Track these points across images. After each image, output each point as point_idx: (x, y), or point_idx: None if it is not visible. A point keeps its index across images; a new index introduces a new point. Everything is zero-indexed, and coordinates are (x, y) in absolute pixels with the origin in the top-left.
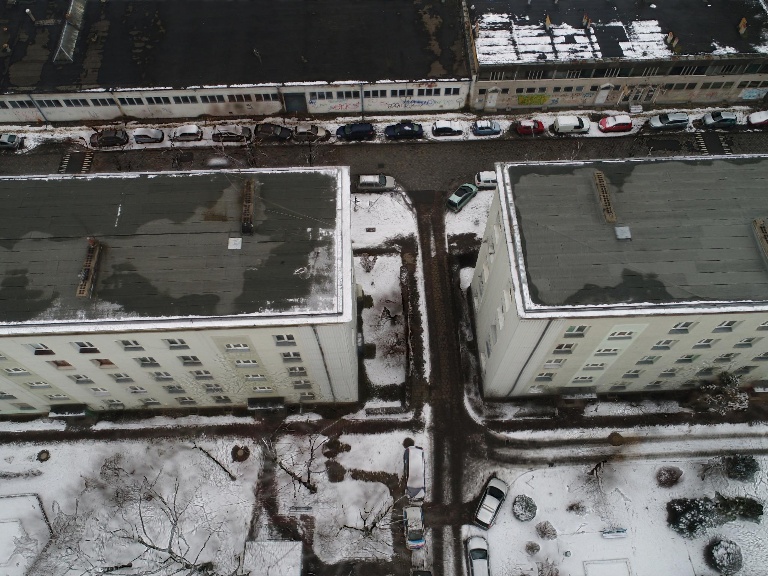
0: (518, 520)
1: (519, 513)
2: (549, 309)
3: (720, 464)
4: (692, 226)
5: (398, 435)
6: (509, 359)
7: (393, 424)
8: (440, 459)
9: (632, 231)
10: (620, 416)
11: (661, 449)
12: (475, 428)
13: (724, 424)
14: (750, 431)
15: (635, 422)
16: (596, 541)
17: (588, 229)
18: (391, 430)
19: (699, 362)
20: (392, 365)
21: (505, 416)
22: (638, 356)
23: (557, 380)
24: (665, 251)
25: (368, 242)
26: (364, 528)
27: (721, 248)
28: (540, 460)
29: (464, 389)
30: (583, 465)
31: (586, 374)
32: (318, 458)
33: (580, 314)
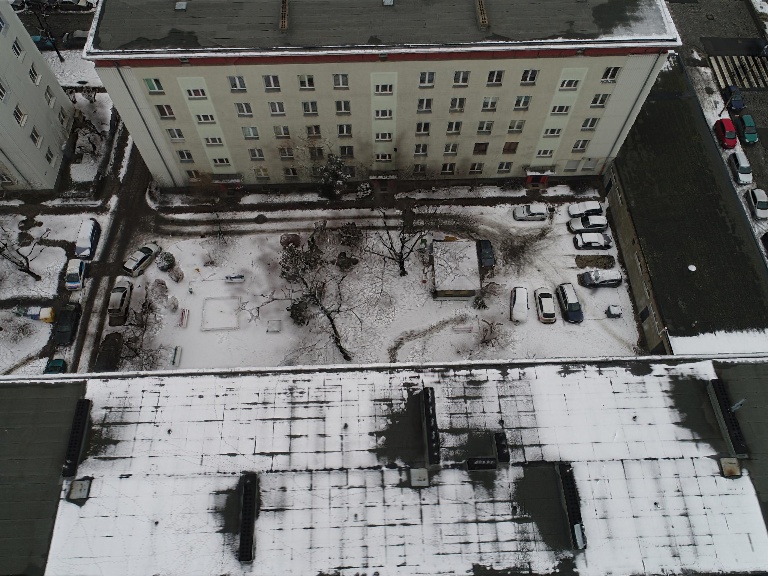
0: (162, 271)
1: (158, 262)
2: (104, 52)
3: (322, 225)
4: (236, 3)
5: (84, 216)
6: (131, 127)
7: (82, 208)
8: (114, 233)
9: (189, 5)
10: (269, 203)
11: (295, 226)
12: (149, 212)
13: (351, 209)
14: (371, 214)
15: (280, 208)
16: (220, 285)
17: (156, 4)
18: (79, 212)
19: (296, 138)
20: (93, 168)
21: (175, 203)
22: (236, 126)
23: (199, 162)
24: (208, 18)
25: (100, 83)
26: (20, 263)
27: (252, 16)
28: (195, 233)
29: (148, 185)
30: (228, 236)
31: (216, 153)
32: (13, 230)
33: (128, 56)
